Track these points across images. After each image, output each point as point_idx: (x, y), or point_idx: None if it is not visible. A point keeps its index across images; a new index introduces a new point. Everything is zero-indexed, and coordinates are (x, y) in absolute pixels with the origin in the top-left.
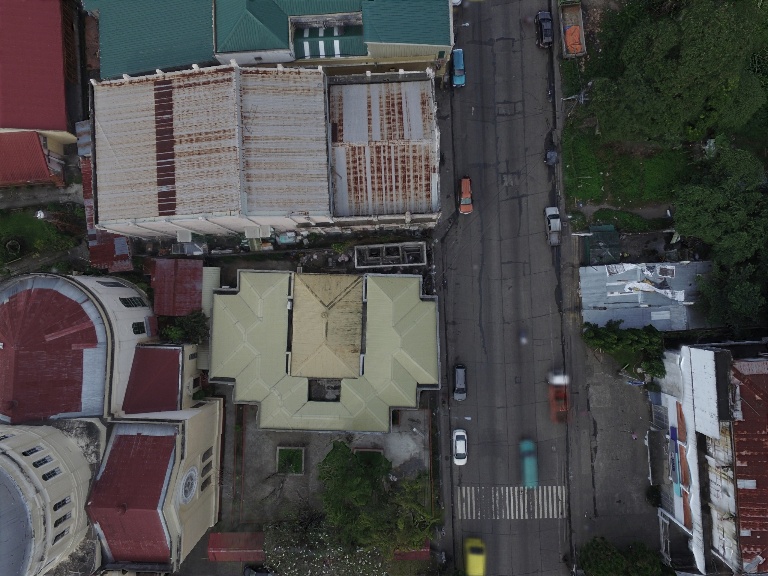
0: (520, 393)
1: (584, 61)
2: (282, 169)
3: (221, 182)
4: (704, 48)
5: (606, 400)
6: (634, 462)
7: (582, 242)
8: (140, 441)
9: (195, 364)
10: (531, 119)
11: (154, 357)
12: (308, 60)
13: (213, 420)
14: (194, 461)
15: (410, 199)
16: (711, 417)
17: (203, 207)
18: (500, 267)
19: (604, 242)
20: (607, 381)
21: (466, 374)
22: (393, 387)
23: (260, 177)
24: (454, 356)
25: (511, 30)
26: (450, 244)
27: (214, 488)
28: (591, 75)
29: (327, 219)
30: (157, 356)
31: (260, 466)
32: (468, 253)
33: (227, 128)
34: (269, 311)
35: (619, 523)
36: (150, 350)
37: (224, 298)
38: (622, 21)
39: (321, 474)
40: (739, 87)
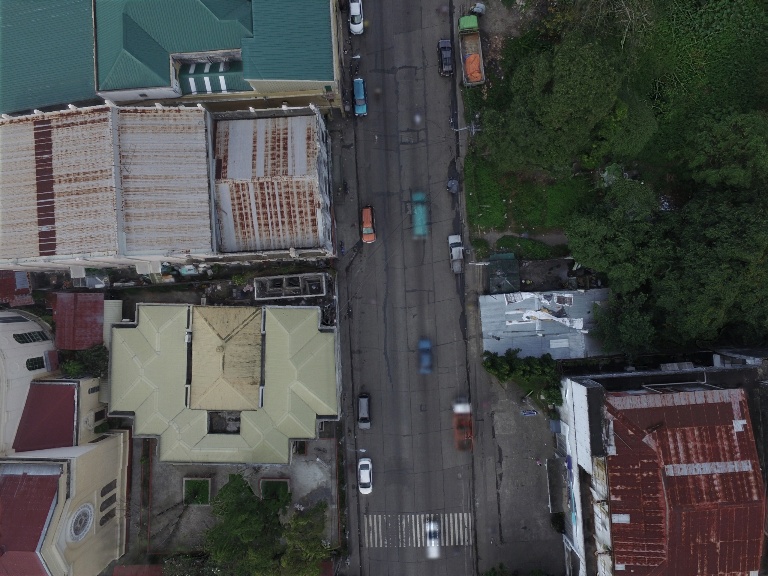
0: (425, 421)
1: (486, 89)
2: (162, 208)
3: (99, 222)
4: (571, 85)
5: (511, 427)
6: (539, 488)
7: (486, 269)
8: (25, 481)
9: (98, 397)
10: (434, 147)
11: (49, 393)
12: (195, 96)
13: (116, 453)
14: (88, 497)
15: (297, 234)
16: (586, 452)
17: (82, 247)
18: (404, 295)
19: (503, 271)
20: (512, 408)
21: (371, 403)
22: (291, 419)
23: (139, 216)
24: (360, 385)
25: (414, 58)
26: (355, 273)
27: (119, 521)
28: (493, 103)
29: (212, 256)
30: (52, 392)
31: (167, 497)
32: (373, 282)
33: (104, 168)
34: (167, 345)
35: (525, 549)
36: (45, 386)
37: (123, 332)
38: (516, 51)
39: (214, 509)
40: (629, 117)
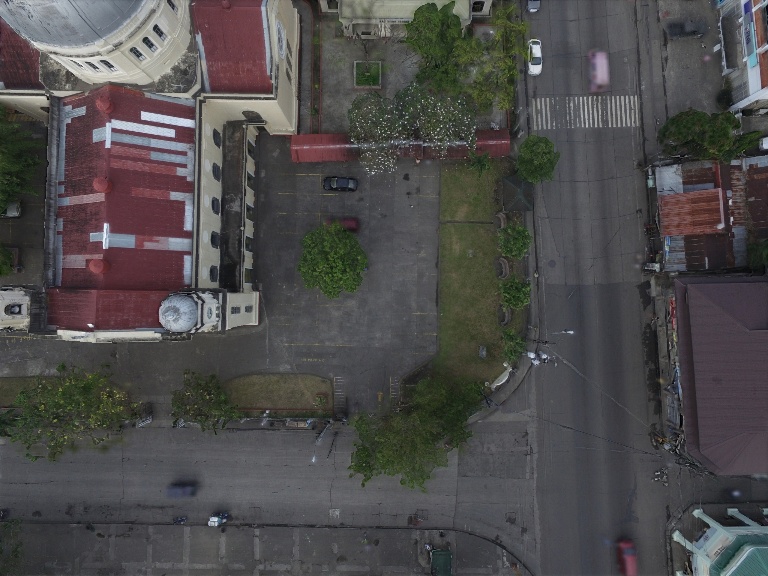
0: (591, 6)
1: None
2: None
3: None
4: None
5: (675, 11)
6: (704, 70)
7: None
8: None
9: None
10: None
11: None
12: None
13: (293, 24)
14: (283, 25)
15: None
16: None
17: None
18: None
19: None
20: None
21: None
22: None
23: None
24: None
25: None
26: None
27: (294, 94)
28: None
29: None
30: None
31: (337, 82)
32: None
33: None
34: None
35: None
36: None
37: None
38: None
39: (409, 34)
40: None
